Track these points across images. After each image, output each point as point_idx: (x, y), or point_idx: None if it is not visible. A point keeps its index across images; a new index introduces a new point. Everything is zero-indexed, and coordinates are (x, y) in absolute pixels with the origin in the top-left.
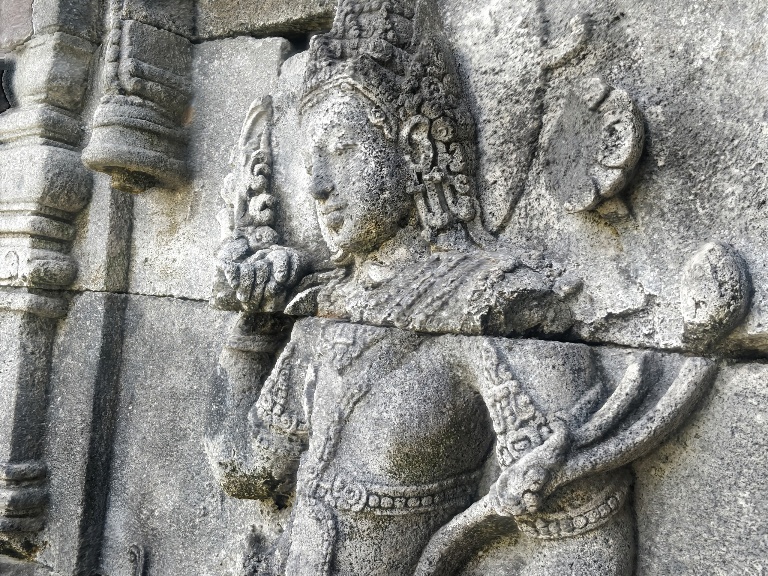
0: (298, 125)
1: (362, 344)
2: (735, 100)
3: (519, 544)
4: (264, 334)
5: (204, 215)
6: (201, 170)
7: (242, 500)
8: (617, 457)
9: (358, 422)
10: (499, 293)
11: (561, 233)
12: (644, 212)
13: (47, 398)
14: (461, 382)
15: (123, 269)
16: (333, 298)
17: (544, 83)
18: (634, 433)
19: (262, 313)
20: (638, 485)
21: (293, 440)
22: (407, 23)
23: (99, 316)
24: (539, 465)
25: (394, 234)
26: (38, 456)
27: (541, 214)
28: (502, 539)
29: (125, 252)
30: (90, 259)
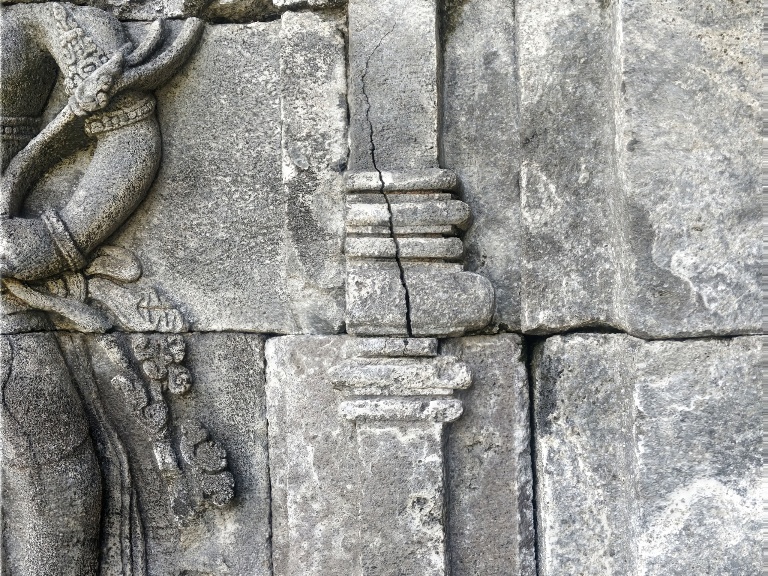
0: None
1: None
2: None
3: (77, 162)
4: None
5: None
6: None
7: None
8: (153, 72)
9: None
10: None
11: None
12: None
13: None
14: (32, 40)
15: None
16: None
17: None
18: (161, 59)
19: None
20: (159, 105)
21: None
22: None
23: None
24: (107, 73)
25: None
26: None
27: None
28: (63, 162)
29: None
30: None
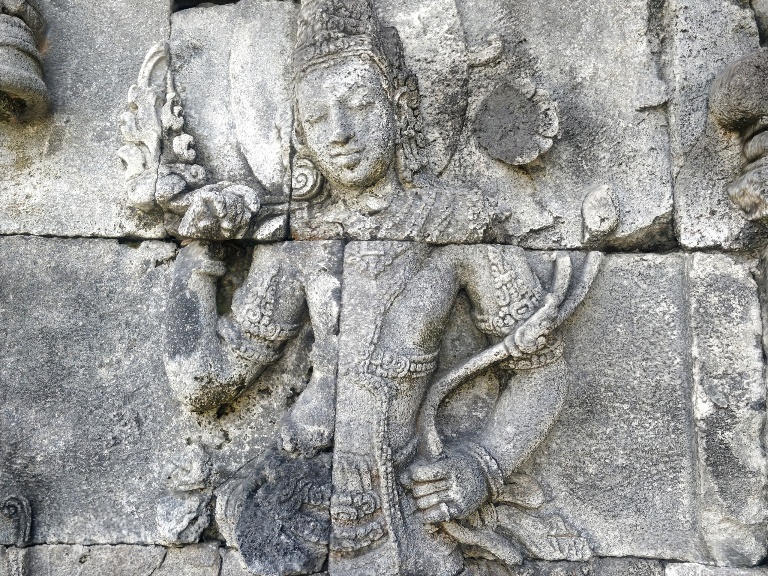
0: (207, 75)
1: (394, 254)
2: (600, 105)
3: (476, 387)
4: (221, 260)
5: (72, 151)
6: (63, 104)
7: (171, 419)
8: None
9: (398, 312)
10: (488, 215)
11: (491, 178)
12: (549, 167)
13: None
14: (458, 278)
15: None
16: (315, 225)
17: (468, 76)
18: (579, 296)
19: (217, 242)
20: None
21: (269, 347)
22: (373, 13)
23: None
24: (548, 318)
25: (386, 174)
26: None
27: (472, 165)
28: (462, 387)
29: None
30: None
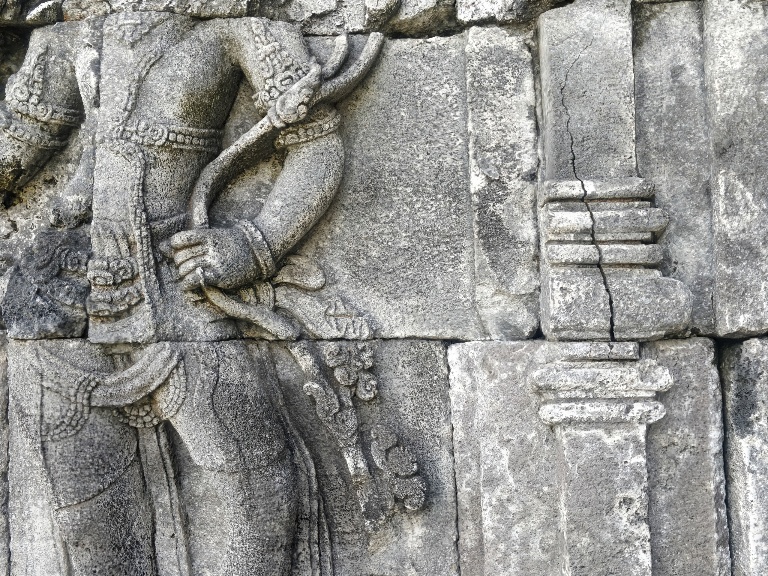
0: None
1: (151, 23)
2: None
3: (259, 173)
4: None
5: None
6: None
7: None
8: (345, 85)
9: (155, 80)
10: None
11: None
12: None
13: None
14: (226, 54)
15: None
16: (85, 5)
17: None
18: (352, 72)
19: None
20: None
21: (44, 130)
22: None
23: None
24: (308, 86)
25: None
26: None
27: None
28: (245, 173)
29: None
30: None
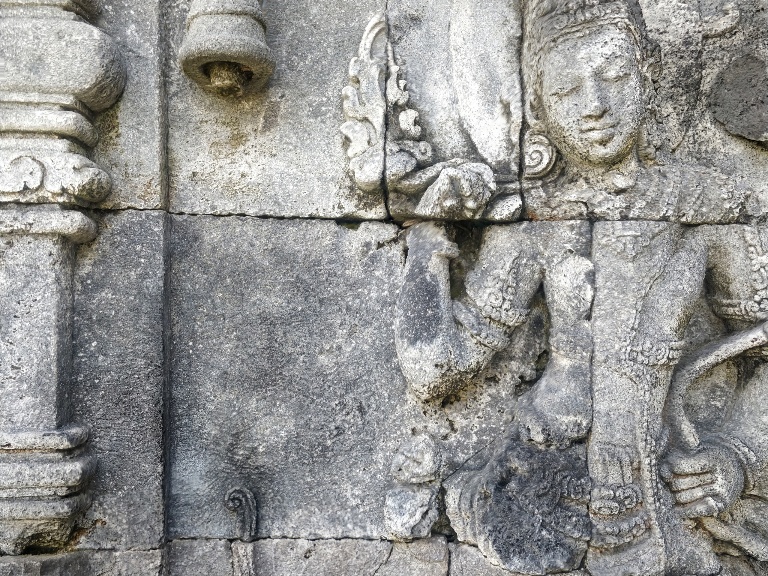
0: (427, 47)
1: (651, 235)
2: None
3: (714, 375)
4: None
5: (288, 127)
6: (279, 78)
7: (396, 408)
8: None
9: (657, 295)
10: None
11: (727, 155)
12: None
13: (72, 345)
14: None
15: (167, 184)
16: (555, 204)
17: (702, 47)
18: None
19: (450, 222)
20: None
21: (506, 333)
22: None
23: (156, 239)
24: None
25: None
26: (72, 418)
27: (707, 141)
28: None
29: (166, 164)
30: (130, 171)
